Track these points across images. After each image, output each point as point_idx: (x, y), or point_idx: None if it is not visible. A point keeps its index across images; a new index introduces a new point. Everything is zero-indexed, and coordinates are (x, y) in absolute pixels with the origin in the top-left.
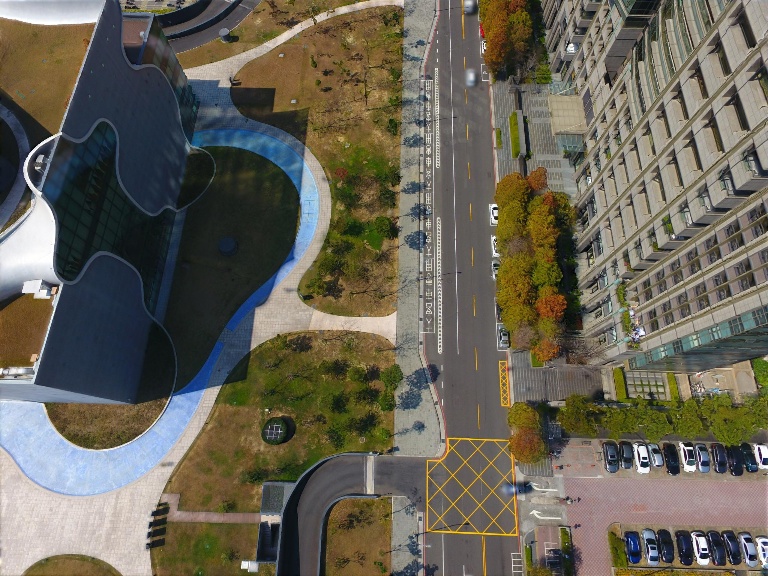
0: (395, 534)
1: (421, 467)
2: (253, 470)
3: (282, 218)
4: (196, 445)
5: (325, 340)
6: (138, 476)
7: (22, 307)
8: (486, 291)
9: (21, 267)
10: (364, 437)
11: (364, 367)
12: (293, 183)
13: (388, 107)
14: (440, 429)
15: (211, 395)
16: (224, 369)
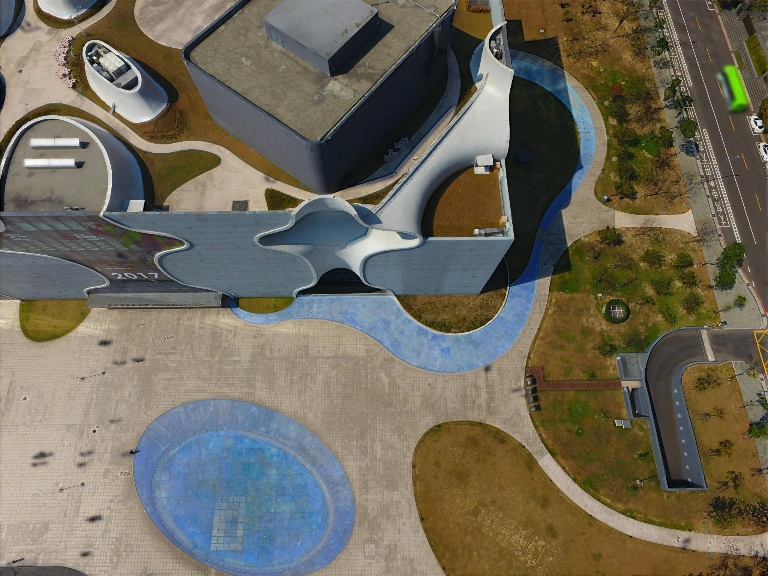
0: (744, 392)
1: (750, 337)
2: (602, 345)
3: (562, 133)
4: (543, 327)
5: (634, 235)
6: (499, 354)
7: (468, 181)
8: (765, 190)
9: (481, 141)
10: (693, 314)
11: (675, 257)
12: (563, 103)
13: (630, 34)
14: (758, 306)
15: (544, 285)
16: (549, 263)
